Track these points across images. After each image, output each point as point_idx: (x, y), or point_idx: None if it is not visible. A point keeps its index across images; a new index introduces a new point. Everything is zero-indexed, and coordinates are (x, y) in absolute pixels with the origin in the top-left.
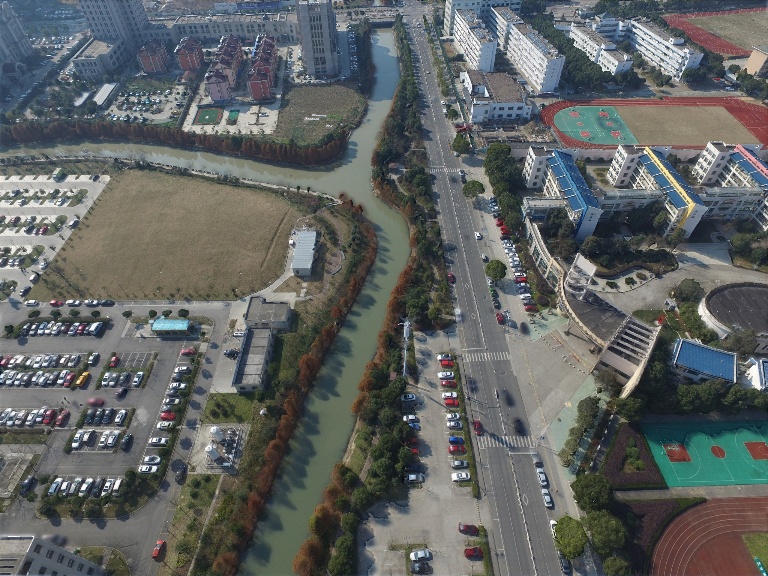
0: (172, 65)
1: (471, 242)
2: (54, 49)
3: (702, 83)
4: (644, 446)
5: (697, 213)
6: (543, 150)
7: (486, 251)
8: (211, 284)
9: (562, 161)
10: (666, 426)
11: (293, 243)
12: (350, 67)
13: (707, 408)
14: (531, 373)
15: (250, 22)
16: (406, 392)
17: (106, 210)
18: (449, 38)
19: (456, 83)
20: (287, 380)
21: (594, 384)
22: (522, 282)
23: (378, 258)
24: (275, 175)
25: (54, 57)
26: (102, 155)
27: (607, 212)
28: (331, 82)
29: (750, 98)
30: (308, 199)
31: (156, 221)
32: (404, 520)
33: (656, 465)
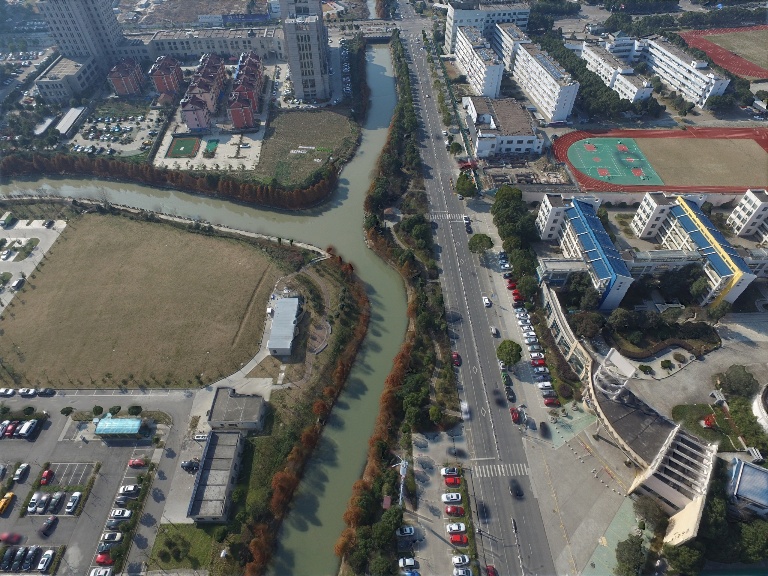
0: (148, 86)
1: (479, 310)
2: (20, 66)
3: (728, 111)
4: None
5: (743, 281)
6: (560, 198)
7: (496, 322)
8: (172, 367)
9: (583, 214)
10: (726, 575)
11: (271, 311)
12: (342, 89)
13: None
14: (555, 495)
15: (234, 38)
16: (403, 522)
17: (57, 266)
18: (450, 56)
19: (458, 109)
20: (256, 505)
21: (633, 512)
22: (540, 365)
23: (370, 329)
24: (256, 217)
25: (19, 75)
26: (63, 191)
27: (636, 275)
28: (321, 107)
29: None
30: (291, 253)
31: (113, 282)
32: None
33: None
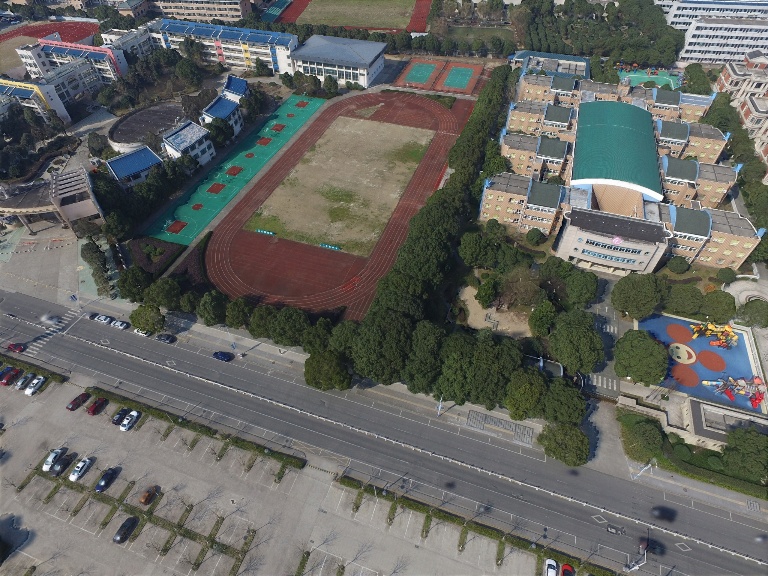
0: None
1: None
2: None
3: None
4: (153, 240)
5: (50, 94)
6: None
7: None
8: None
9: None
10: (157, 221)
11: None
12: None
13: (164, 188)
14: (28, 279)
15: None
16: None
17: None
18: None
19: None
20: None
21: (86, 242)
22: None
23: None
24: None
25: None
26: None
27: None
28: None
29: (38, 22)
30: None
31: None
32: (11, 463)
33: (170, 242)
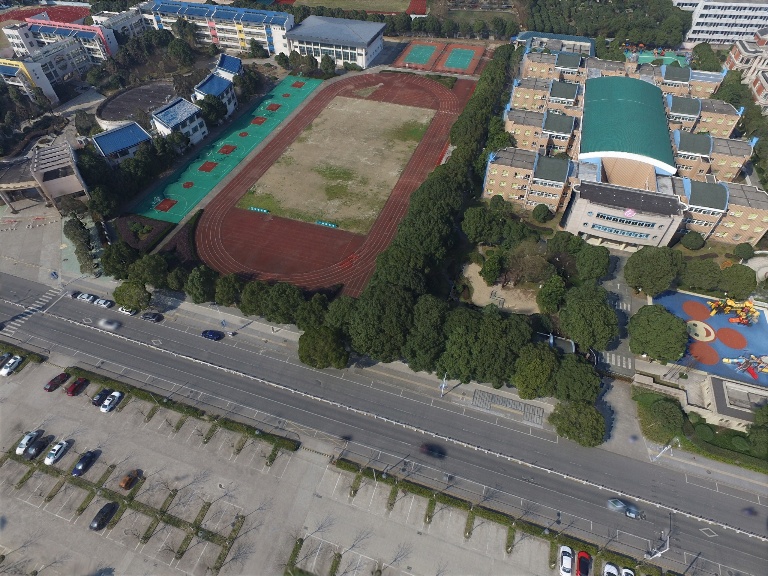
0: None
1: None
2: None
3: None
4: (141, 218)
5: (36, 72)
6: None
7: None
8: None
9: None
10: (146, 199)
11: None
12: None
13: (153, 165)
14: (8, 257)
15: None
16: None
17: None
18: None
19: None
20: None
21: None
22: None
23: None
24: None
25: None
26: None
27: None
28: None
29: (28, 7)
30: None
31: None
32: None
33: (158, 220)
